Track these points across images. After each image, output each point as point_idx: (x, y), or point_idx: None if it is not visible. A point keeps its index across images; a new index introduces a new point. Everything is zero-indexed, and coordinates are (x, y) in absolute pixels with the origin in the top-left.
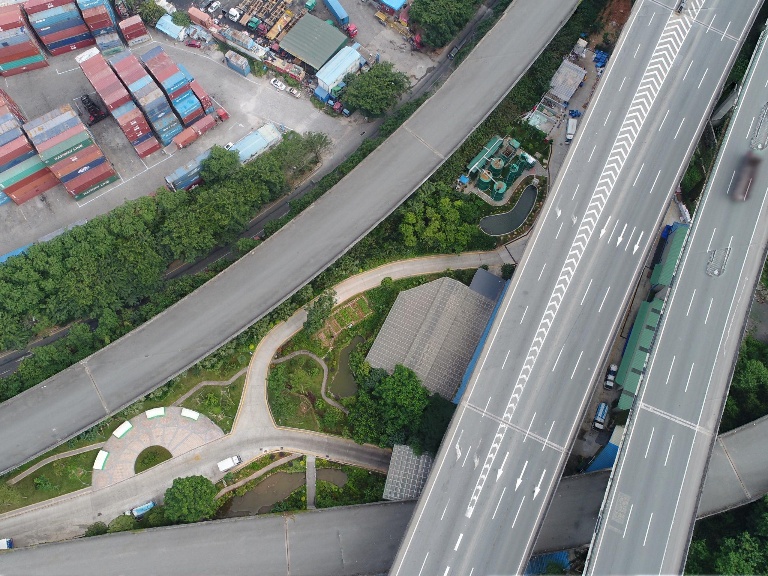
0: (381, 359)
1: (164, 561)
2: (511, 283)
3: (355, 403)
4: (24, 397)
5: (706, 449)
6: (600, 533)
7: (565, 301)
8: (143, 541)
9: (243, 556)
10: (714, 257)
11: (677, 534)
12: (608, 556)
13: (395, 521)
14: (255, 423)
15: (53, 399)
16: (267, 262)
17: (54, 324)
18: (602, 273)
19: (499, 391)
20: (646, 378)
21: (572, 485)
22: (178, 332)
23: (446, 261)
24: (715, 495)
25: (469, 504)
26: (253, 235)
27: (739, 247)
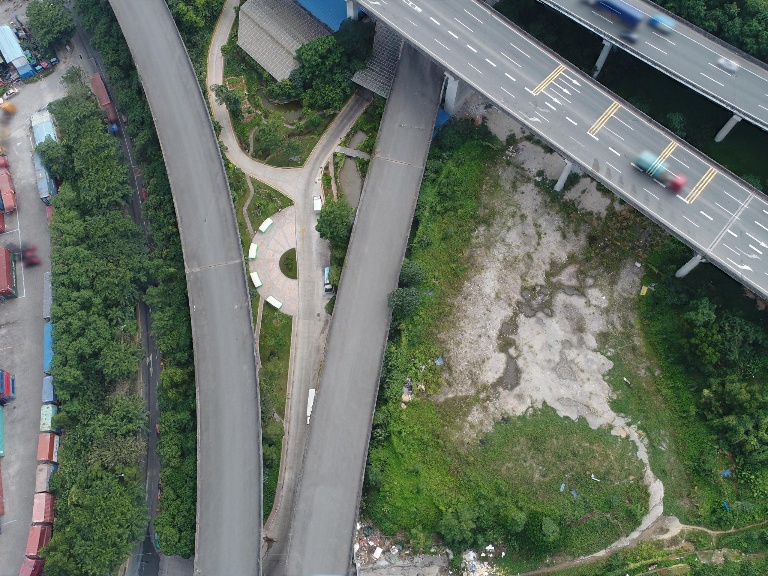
0: (284, 71)
1: (375, 250)
2: None
3: (309, 103)
4: (196, 327)
5: None
6: None
7: None
8: (354, 262)
9: (393, 193)
10: None
11: None
12: None
13: (406, 88)
14: (294, 182)
15: (209, 303)
16: (169, 112)
17: (135, 321)
18: None
19: None
20: None
21: None
22: (196, 192)
23: (226, 18)
24: None
25: (413, 8)
26: (130, 161)
27: None
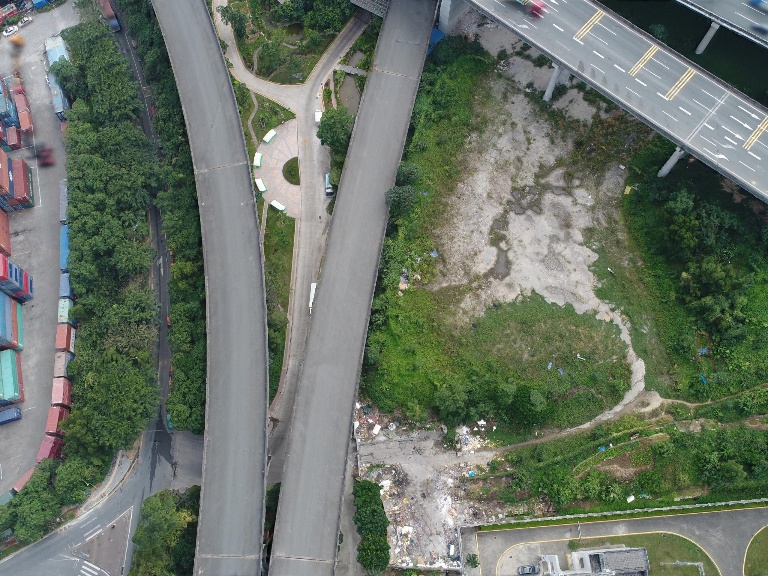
0: None
1: (373, 154)
2: None
3: (310, 24)
4: (205, 222)
5: None
6: None
7: None
8: (354, 164)
9: (390, 103)
10: None
11: None
12: None
13: (402, 7)
14: (296, 97)
15: (217, 200)
16: (177, 29)
17: (146, 224)
18: None
19: None
20: None
21: None
22: (204, 101)
23: None
24: None
25: None
26: None
27: None
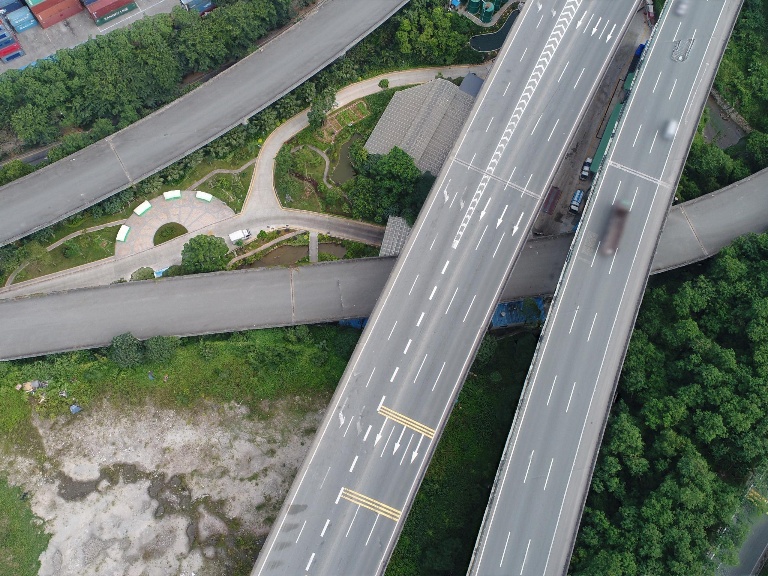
0: (378, 147)
1: (182, 305)
2: (496, 62)
3: (354, 186)
4: (55, 168)
5: (667, 199)
6: (571, 262)
7: (544, 79)
8: (163, 288)
9: (253, 301)
10: (679, 46)
11: (639, 265)
12: (577, 281)
13: None
14: (263, 205)
15: (81, 170)
16: (275, 58)
17: (79, 122)
18: (578, 57)
19: (483, 149)
20: (615, 141)
21: (548, 244)
22: (194, 115)
23: None
24: (676, 253)
25: (455, 238)
26: None
27: (702, 38)
